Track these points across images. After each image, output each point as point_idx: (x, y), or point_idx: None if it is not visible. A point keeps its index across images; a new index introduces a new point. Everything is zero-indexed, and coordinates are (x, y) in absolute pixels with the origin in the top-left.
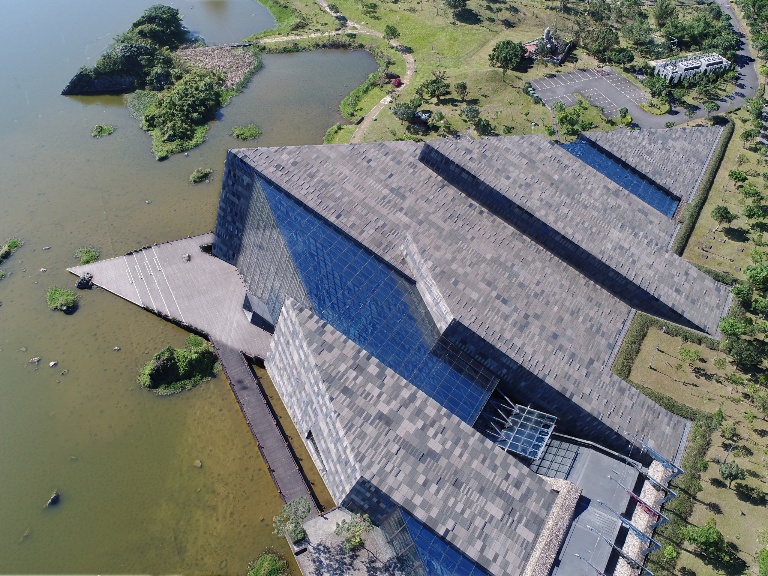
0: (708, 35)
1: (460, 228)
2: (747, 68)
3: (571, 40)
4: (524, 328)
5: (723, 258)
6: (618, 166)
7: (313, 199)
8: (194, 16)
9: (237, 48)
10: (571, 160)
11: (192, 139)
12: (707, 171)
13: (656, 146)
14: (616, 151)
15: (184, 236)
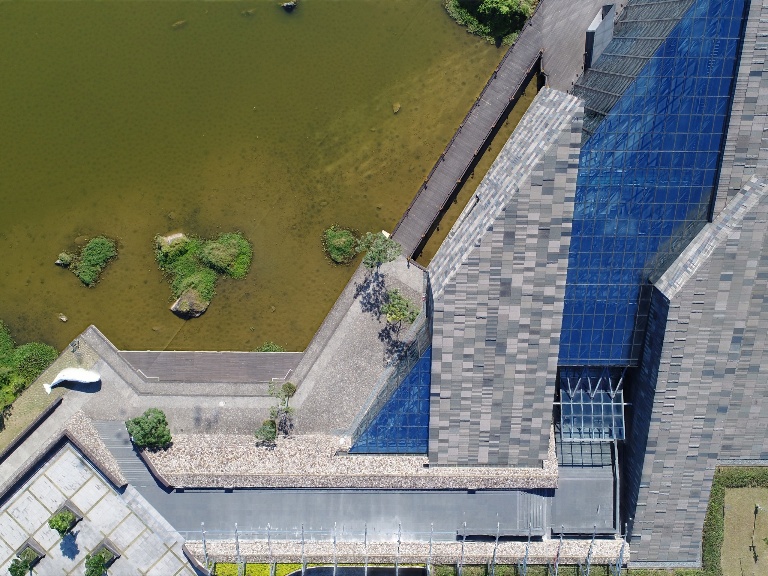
0: None
1: None
2: None
3: None
4: (711, 375)
5: None
6: None
7: (764, 23)
8: None
9: None
10: None
11: None
12: None
13: None
14: None
15: None
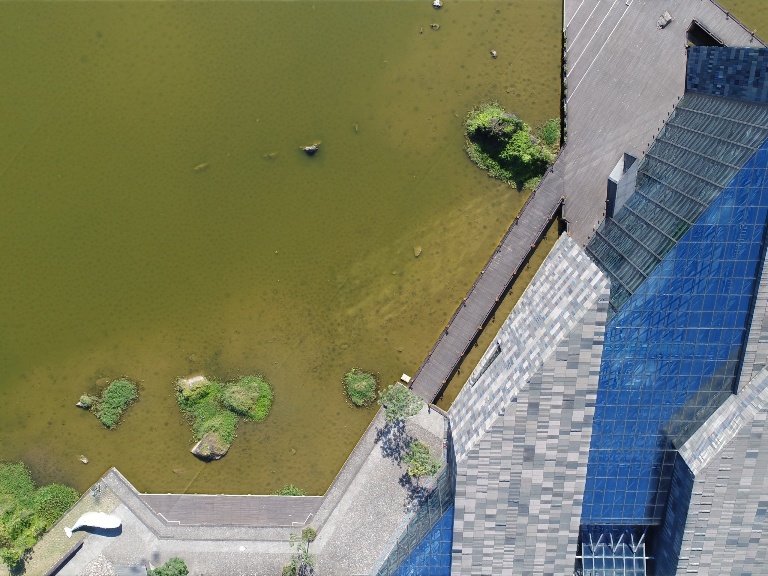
0: None
1: None
2: None
3: None
4: (735, 544)
5: None
6: None
7: None
8: None
9: None
10: None
11: None
12: None
13: None
14: None
15: None
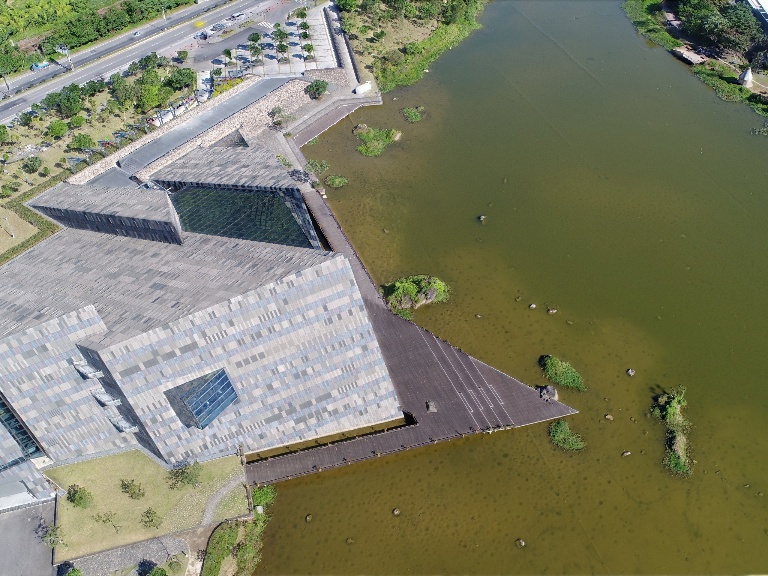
0: None
1: None
2: None
3: None
4: None
5: None
6: None
7: None
8: None
9: None
10: None
11: None
12: None
13: None
14: None
15: (447, 462)
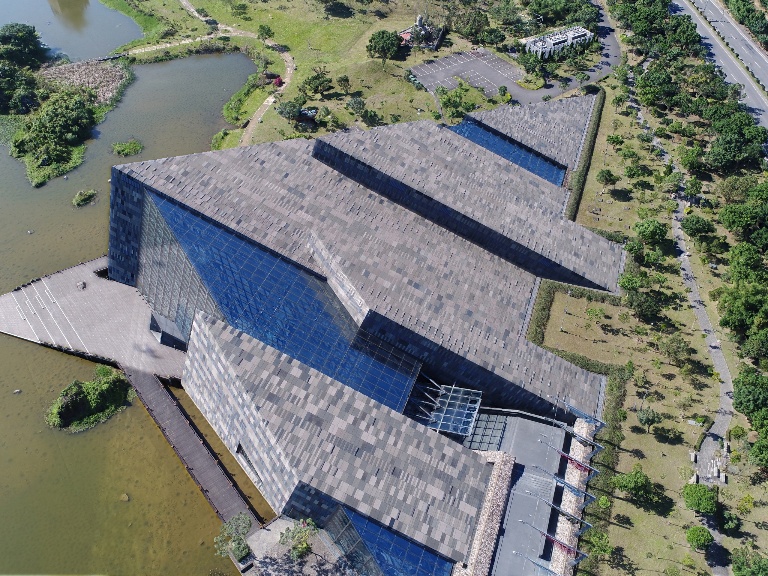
0: (570, 10)
1: (363, 220)
2: (609, 38)
3: (443, 25)
4: (439, 310)
5: (613, 218)
6: (505, 142)
7: (210, 208)
8: (53, 32)
9: (105, 62)
10: (460, 141)
11: (69, 161)
12: (587, 138)
13: (537, 119)
14: (501, 128)
15: (75, 263)
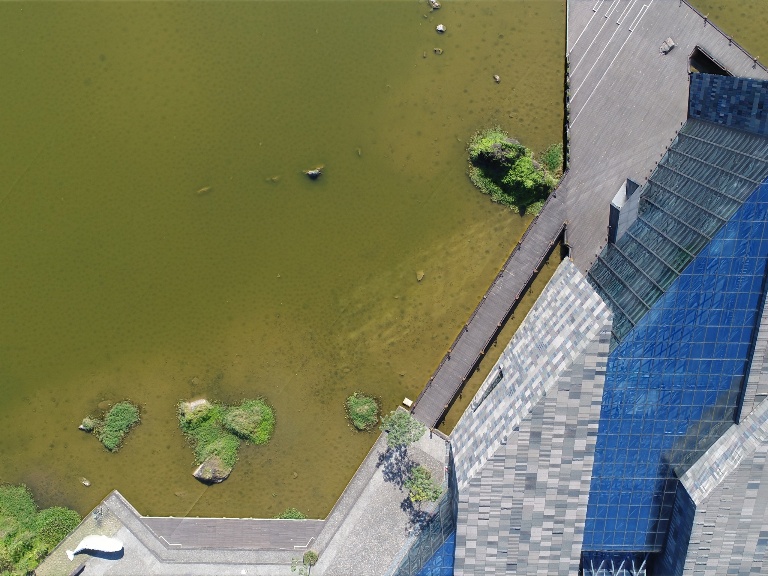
0: None
1: None
2: None
3: None
4: (736, 573)
5: None
6: None
7: None
8: None
9: None
10: None
11: None
12: None
13: None
14: None
15: (708, 2)
